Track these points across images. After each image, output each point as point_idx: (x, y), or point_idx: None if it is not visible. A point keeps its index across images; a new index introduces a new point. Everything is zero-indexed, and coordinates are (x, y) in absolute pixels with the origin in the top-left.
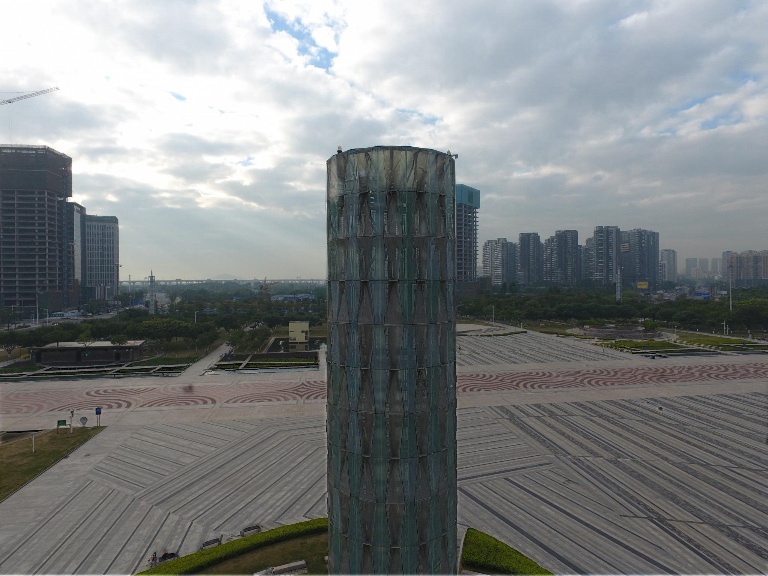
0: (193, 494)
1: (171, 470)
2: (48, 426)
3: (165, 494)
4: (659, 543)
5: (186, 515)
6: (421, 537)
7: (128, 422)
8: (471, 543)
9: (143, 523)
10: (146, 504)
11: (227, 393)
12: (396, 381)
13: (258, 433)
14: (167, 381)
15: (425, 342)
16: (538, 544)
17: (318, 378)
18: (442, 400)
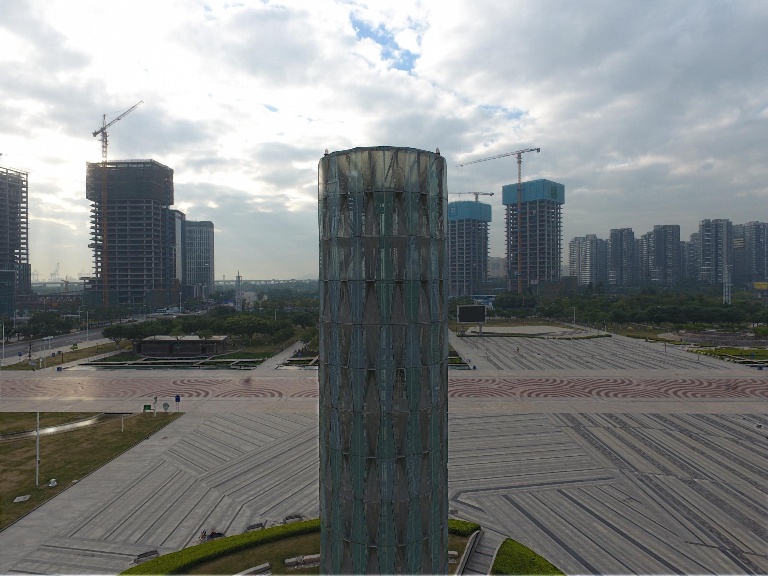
0: (247, 480)
1: (232, 456)
2: (137, 410)
3: (223, 478)
4: None
5: (238, 499)
6: (400, 539)
7: (203, 410)
8: (505, 554)
9: (200, 503)
10: (206, 486)
11: (294, 387)
12: (374, 381)
13: (315, 427)
14: (243, 374)
15: (404, 342)
16: (582, 563)
17: None
18: (424, 402)
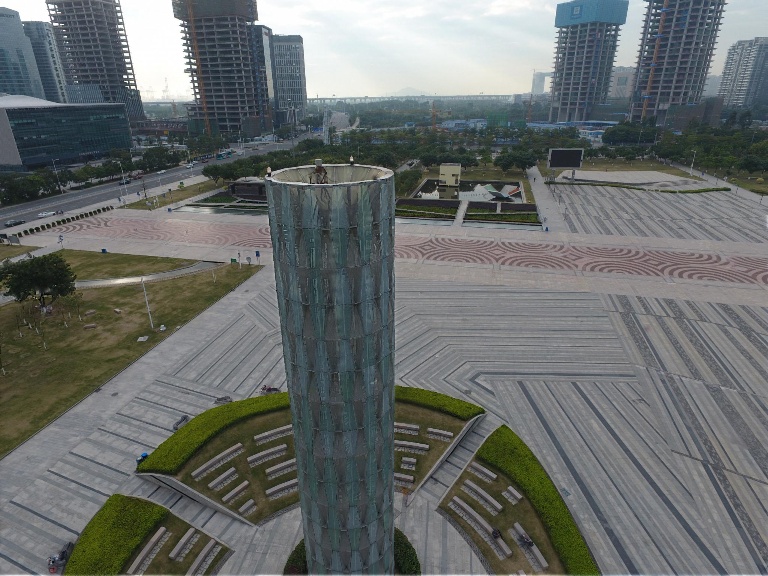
0: None
1: None
2: (228, 260)
3: None
4: (693, 490)
5: None
6: (341, 479)
7: None
8: (492, 442)
9: (266, 358)
10: (272, 342)
11: None
12: None
13: None
14: None
15: (338, 354)
16: (562, 456)
17: (447, 235)
18: (359, 394)
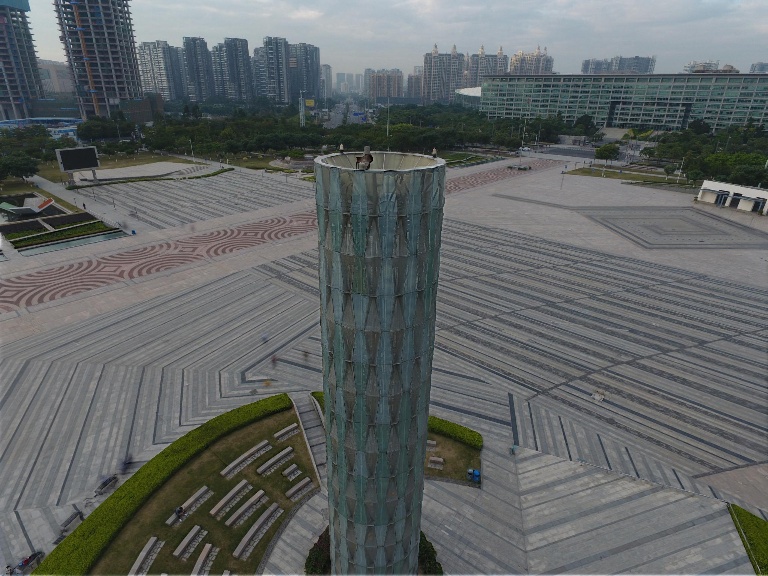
0: None
1: None
2: None
3: None
4: None
5: None
6: None
7: None
8: None
9: None
10: None
11: None
12: (416, 364)
13: None
14: None
15: (432, 327)
16: None
17: (19, 271)
18: None
